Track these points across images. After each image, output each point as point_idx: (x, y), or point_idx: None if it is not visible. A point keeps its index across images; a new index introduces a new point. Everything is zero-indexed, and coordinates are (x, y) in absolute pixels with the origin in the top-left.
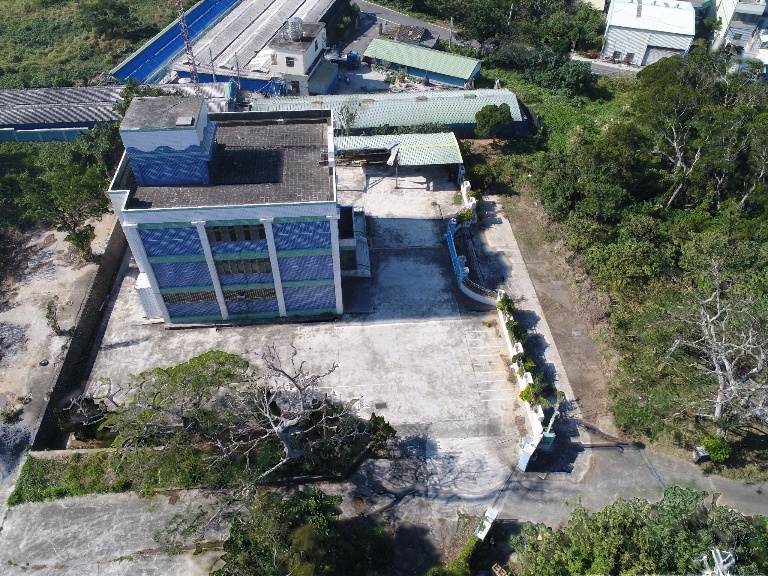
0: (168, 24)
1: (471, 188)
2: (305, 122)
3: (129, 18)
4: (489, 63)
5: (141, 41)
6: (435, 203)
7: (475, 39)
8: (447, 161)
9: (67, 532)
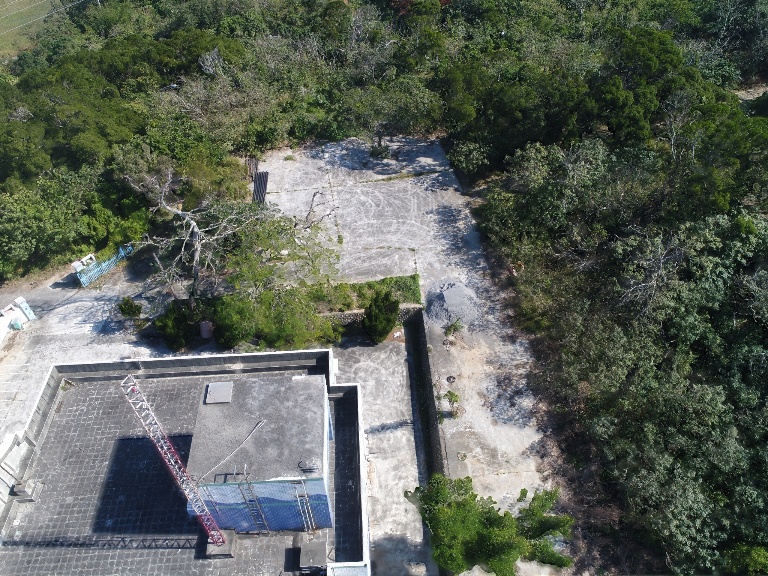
0: None
1: None
2: None
3: None
4: None
5: None
6: None
7: None
8: None
9: (370, 263)
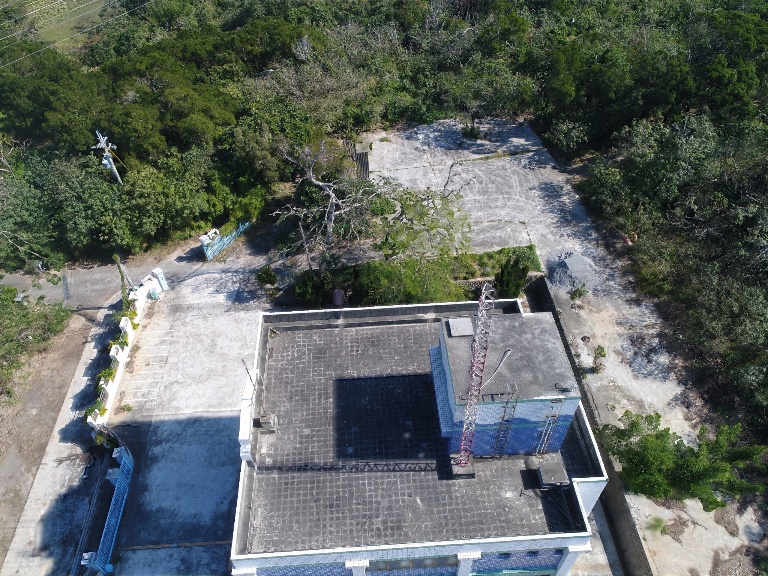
0: None
1: None
2: None
3: None
4: None
5: None
6: None
7: None
8: None
9: (484, 235)
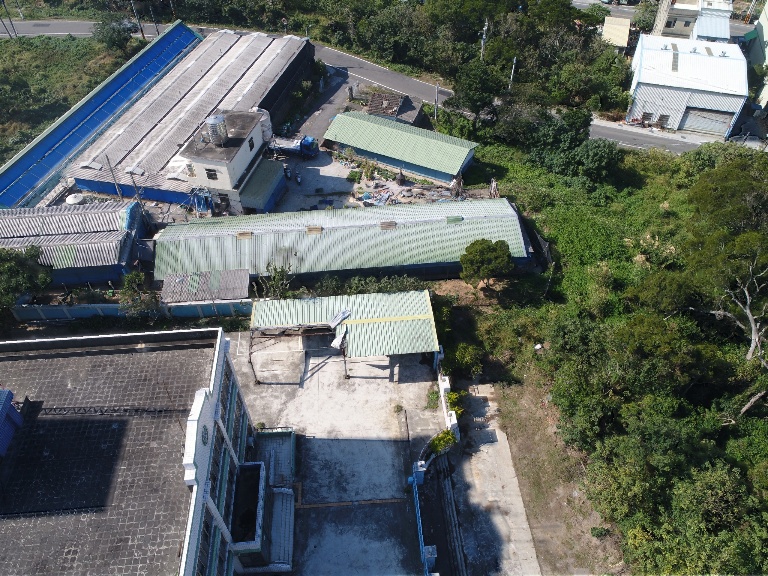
0: (82, 97)
1: (453, 378)
2: (180, 347)
3: (34, 90)
4: (486, 137)
5: (43, 124)
6: (399, 408)
7: (468, 107)
8: (416, 348)
9: None
